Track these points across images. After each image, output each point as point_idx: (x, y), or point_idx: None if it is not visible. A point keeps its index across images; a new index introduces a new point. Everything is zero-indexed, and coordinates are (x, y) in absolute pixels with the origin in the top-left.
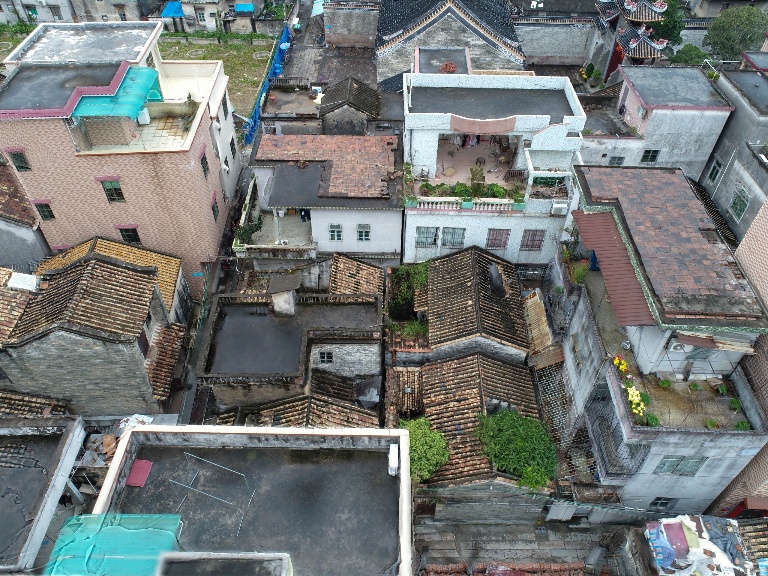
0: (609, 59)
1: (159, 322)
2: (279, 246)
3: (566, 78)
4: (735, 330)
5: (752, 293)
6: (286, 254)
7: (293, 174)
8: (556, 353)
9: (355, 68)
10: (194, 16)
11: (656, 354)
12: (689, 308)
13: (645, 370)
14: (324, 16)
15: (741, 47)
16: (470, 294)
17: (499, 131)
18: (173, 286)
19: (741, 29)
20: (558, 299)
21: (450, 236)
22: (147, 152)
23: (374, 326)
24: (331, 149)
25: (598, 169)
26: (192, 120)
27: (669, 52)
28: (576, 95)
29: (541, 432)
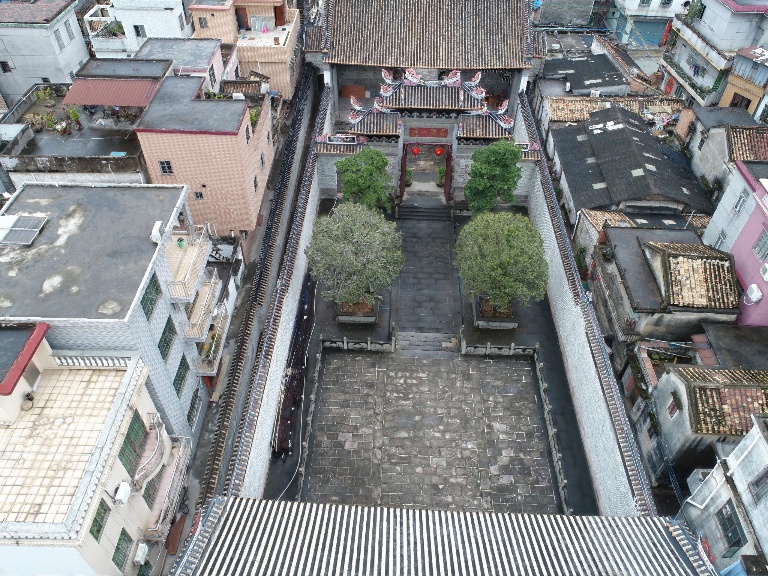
0: None
1: None
2: None
3: None
4: None
5: None
6: None
7: None
8: None
9: None
10: None
11: None
12: None
13: None
14: None
15: None
16: None
17: None
18: None
19: None
20: None
21: None
22: None
23: None
24: None
25: (65, 3)
26: None
27: None
28: None
29: None
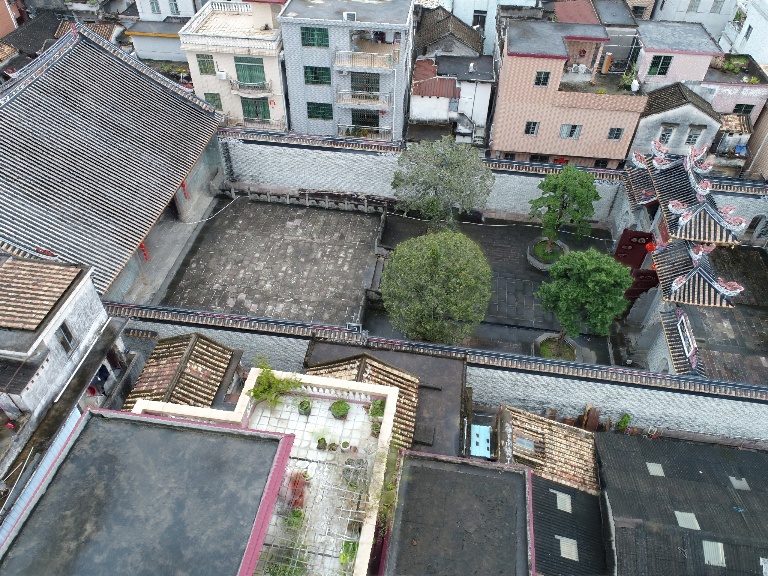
0: None
1: None
2: None
3: None
4: None
5: None
6: None
7: None
8: None
9: None
10: None
11: None
12: None
13: None
14: None
15: None
16: None
17: None
18: None
19: None
20: None
21: None
22: None
23: None
24: None
25: None
26: None
27: None
28: (767, 1)
29: None
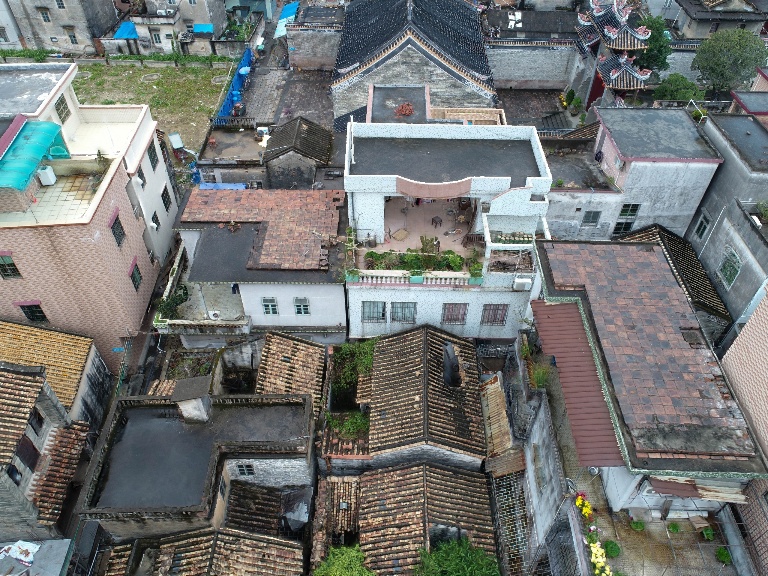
0: (590, 86)
1: (56, 422)
2: (206, 322)
3: (532, 128)
4: (722, 475)
5: (743, 421)
6: (215, 330)
7: (221, 239)
8: (517, 458)
9: (320, 94)
10: (149, 38)
11: (627, 494)
12: (665, 445)
13: (615, 507)
14: (287, 38)
15: (732, 73)
16: (418, 387)
17: (452, 195)
18: (79, 374)
19: (732, 54)
20: (517, 400)
21: (400, 311)
22: (39, 225)
23: (298, 439)
24: (268, 207)
25: (563, 246)
26: (102, 181)
27: (655, 78)
28: None
29: (493, 572)
